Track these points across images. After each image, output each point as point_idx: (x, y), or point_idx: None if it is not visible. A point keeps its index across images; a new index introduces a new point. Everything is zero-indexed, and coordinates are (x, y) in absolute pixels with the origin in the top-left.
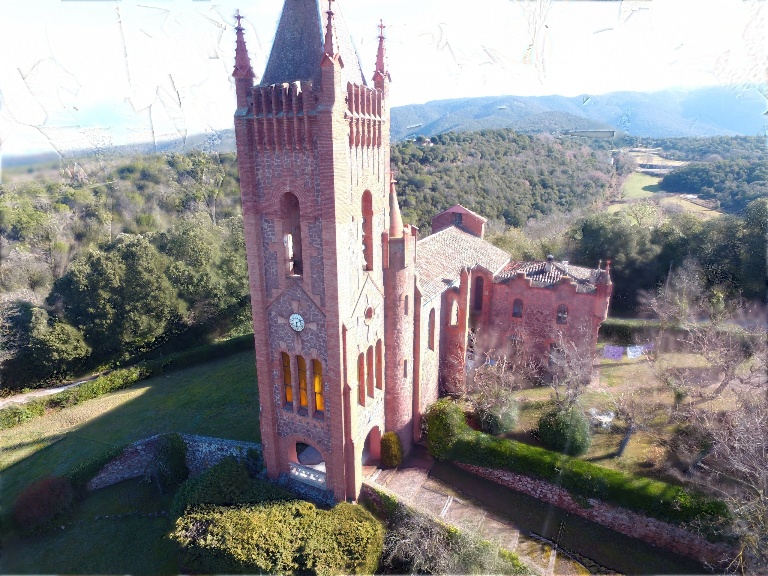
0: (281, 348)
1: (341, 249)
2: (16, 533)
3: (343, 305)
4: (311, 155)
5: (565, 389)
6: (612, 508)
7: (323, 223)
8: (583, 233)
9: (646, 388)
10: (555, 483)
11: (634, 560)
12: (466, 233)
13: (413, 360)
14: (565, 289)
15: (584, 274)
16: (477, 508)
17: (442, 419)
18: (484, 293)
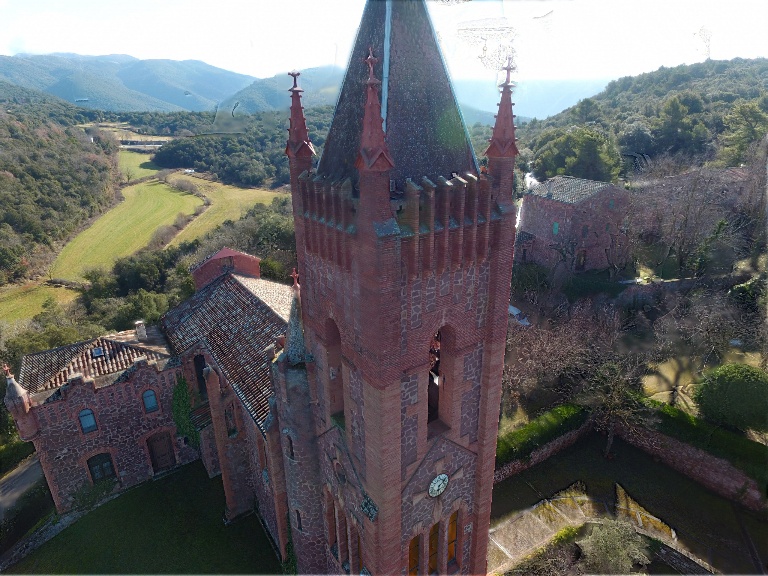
0: (415, 534)
1: None
2: None
3: None
4: (477, 269)
5: None
6: (541, 449)
7: (493, 348)
8: (282, 241)
9: None
10: (511, 460)
11: (565, 471)
12: (249, 278)
13: None
14: None
15: None
16: (503, 523)
17: None
18: None
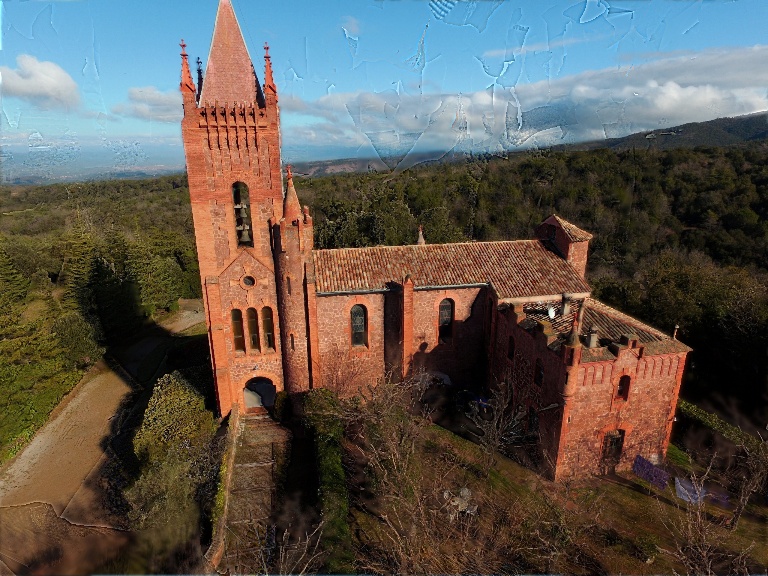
0: None
1: (201, 223)
2: (184, 361)
3: (206, 265)
4: None
5: (511, 466)
6: None
7: None
8: None
9: (617, 534)
10: None
11: None
12: (547, 251)
13: (307, 339)
14: (543, 339)
15: (615, 334)
16: (275, 481)
17: (304, 398)
18: (492, 319)
